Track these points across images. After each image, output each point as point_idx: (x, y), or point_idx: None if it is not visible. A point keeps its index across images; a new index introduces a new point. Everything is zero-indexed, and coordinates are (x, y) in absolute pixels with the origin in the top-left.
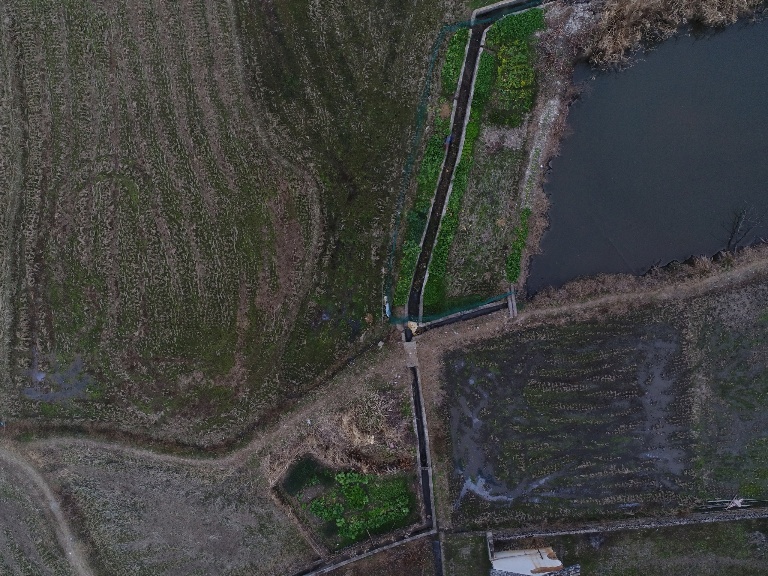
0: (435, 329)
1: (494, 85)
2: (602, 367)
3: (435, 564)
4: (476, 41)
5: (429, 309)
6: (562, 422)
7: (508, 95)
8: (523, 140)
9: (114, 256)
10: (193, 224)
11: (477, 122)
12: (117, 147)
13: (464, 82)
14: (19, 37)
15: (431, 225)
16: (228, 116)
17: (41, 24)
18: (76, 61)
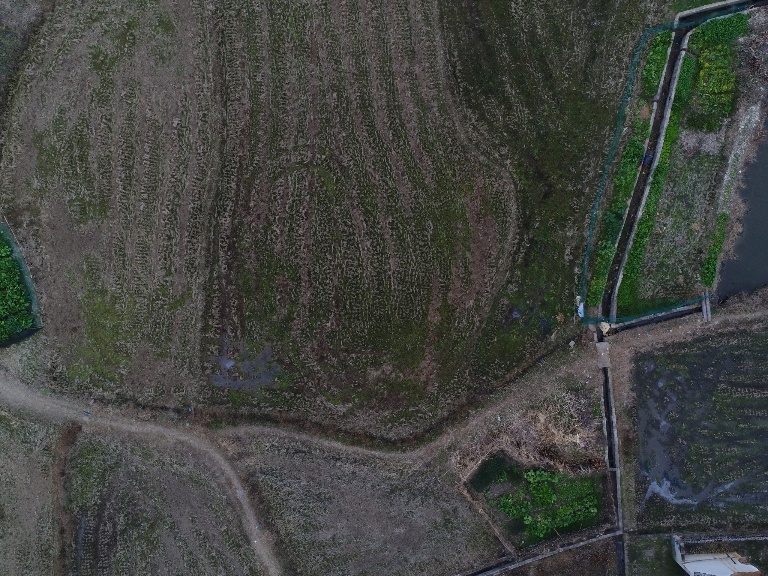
0: (628, 330)
1: (693, 89)
2: None
3: (618, 565)
4: (676, 44)
5: (623, 310)
6: (750, 428)
7: (708, 99)
8: (721, 145)
9: (308, 246)
10: (388, 217)
11: (676, 125)
12: (315, 137)
13: (663, 85)
14: (221, 24)
15: (625, 226)
16: (427, 110)
17: (243, 12)
18: (277, 50)
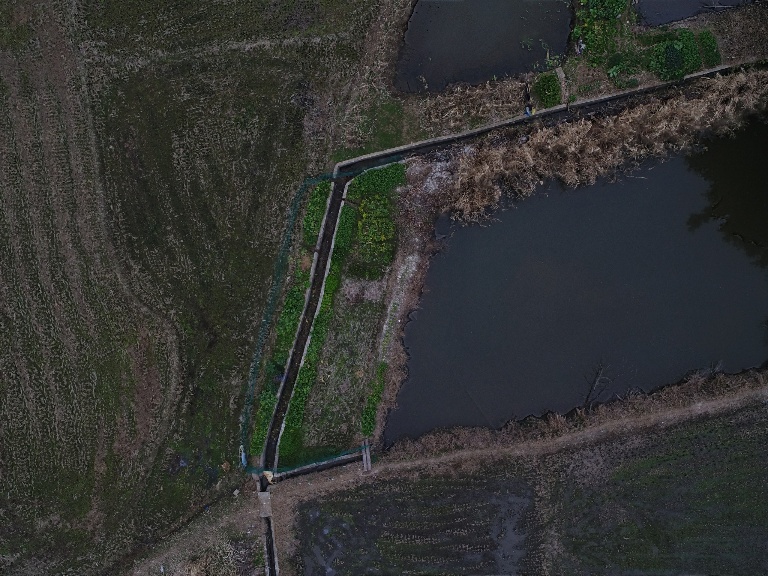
0: (290, 480)
1: (356, 237)
2: (455, 521)
3: None
4: (339, 192)
5: (284, 460)
6: (414, 574)
7: (369, 248)
8: (383, 293)
9: None
10: (53, 368)
11: (337, 274)
12: None
13: (326, 233)
14: None
15: (290, 374)
16: (90, 262)
17: None
18: None
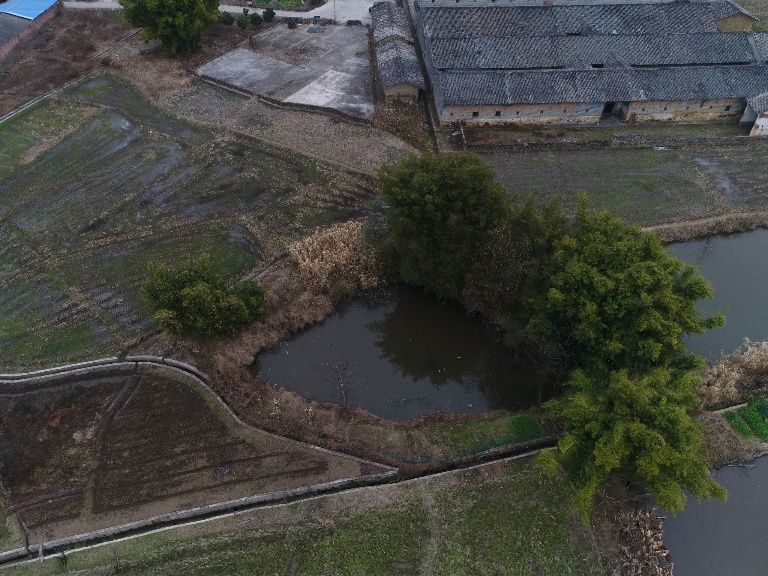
0: None
1: None
2: (763, 190)
3: None
4: None
5: None
6: None
7: None
8: None
9: None
10: None
11: None
12: None
13: None
14: None
15: None
16: None
17: None
18: None
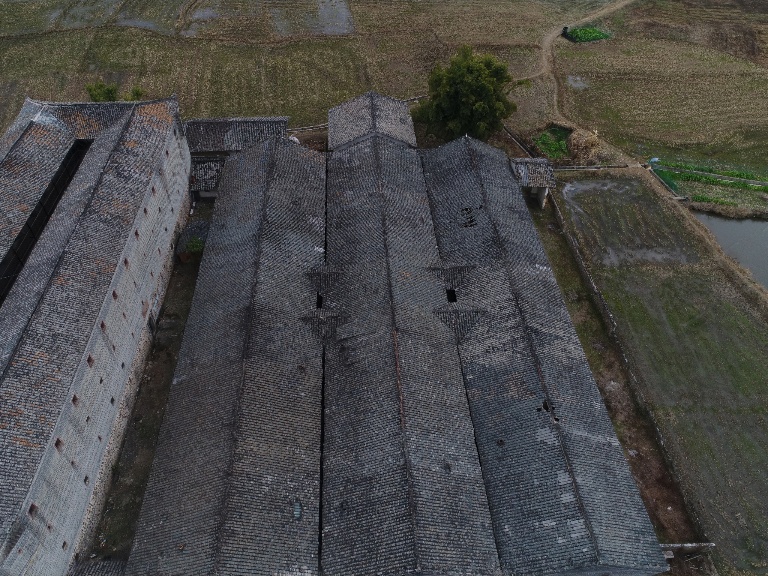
0: None
1: None
2: None
3: None
4: None
5: (662, 172)
6: None
7: None
8: None
9: None
10: None
11: None
12: None
13: None
14: None
15: None
16: None
17: None
18: None
